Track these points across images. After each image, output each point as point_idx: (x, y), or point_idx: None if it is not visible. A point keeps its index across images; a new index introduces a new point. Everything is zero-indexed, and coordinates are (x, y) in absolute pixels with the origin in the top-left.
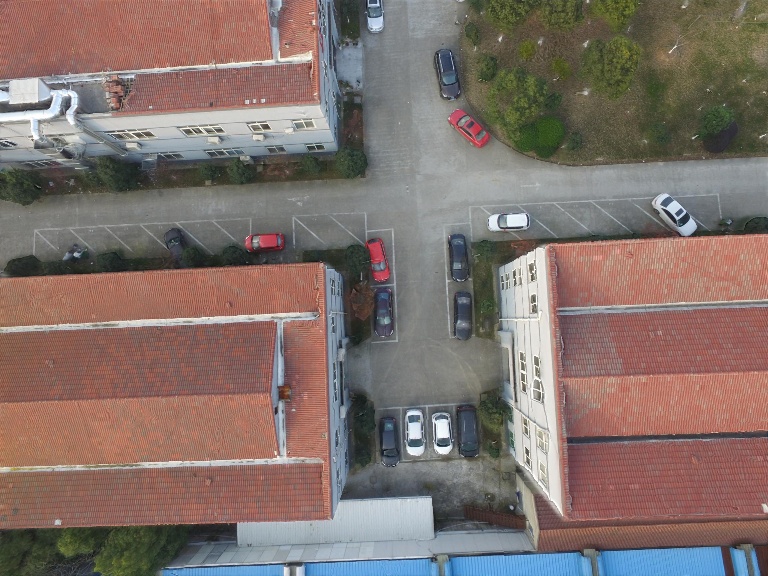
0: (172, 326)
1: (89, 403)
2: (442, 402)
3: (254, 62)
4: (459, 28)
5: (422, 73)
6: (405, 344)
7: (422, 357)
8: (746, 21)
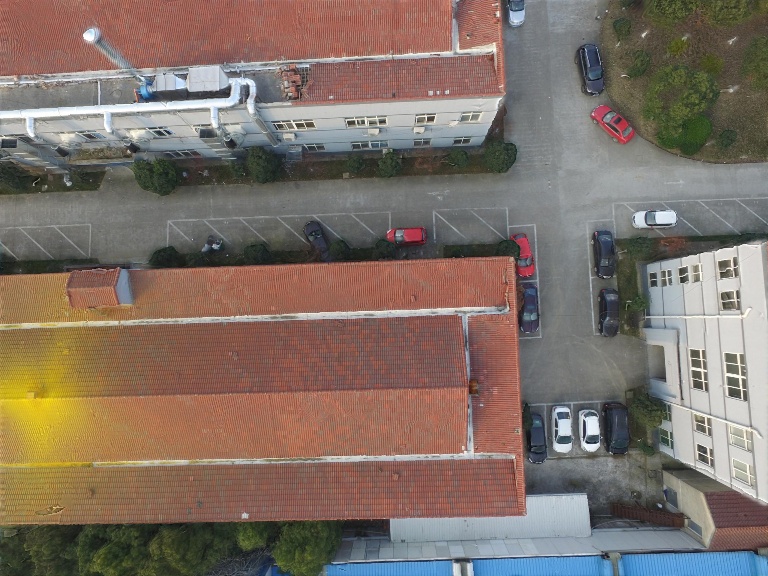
0: (354, 319)
1: (280, 396)
2: (587, 399)
3: (432, 53)
4: (600, 23)
5: (563, 68)
6: (549, 340)
7: (566, 354)
8: None
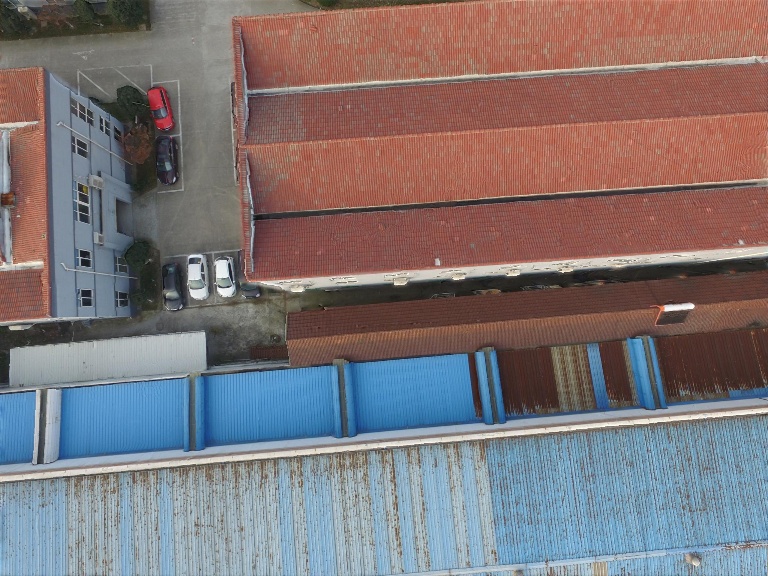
0: None
1: None
2: (228, 248)
3: None
4: None
5: None
6: (191, 193)
7: (208, 205)
8: None
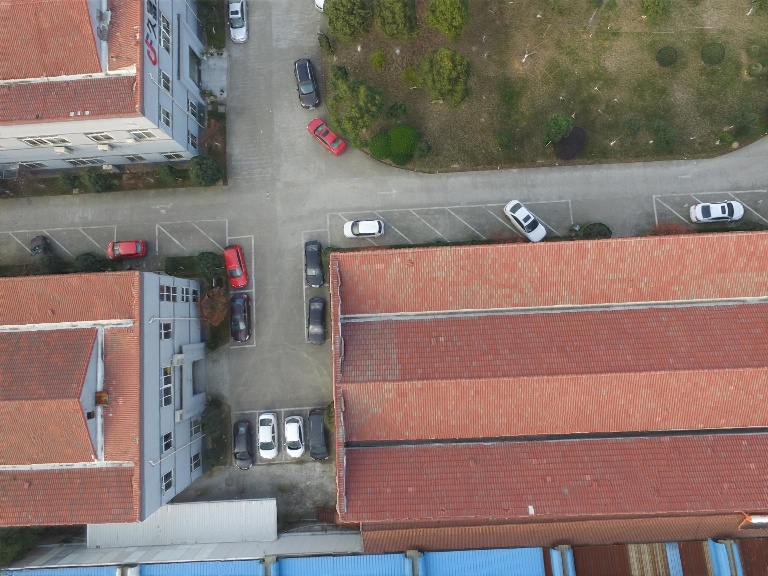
0: None
1: None
2: (297, 406)
3: (84, 75)
4: None
5: (285, 82)
6: (262, 349)
7: (279, 361)
8: (600, 30)
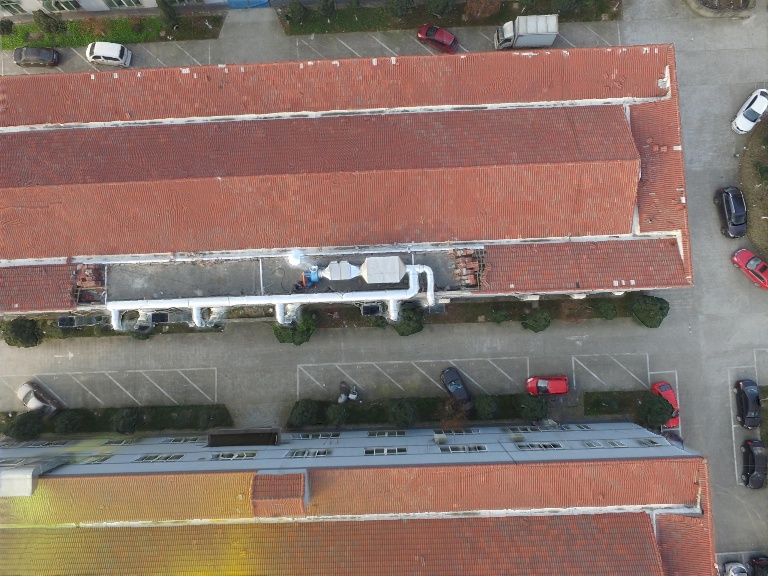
0: (539, 517)
1: None
2: (731, 550)
3: (611, 235)
4: (738, 161)
5: (702, 208)
6: None
7: None
8: None
